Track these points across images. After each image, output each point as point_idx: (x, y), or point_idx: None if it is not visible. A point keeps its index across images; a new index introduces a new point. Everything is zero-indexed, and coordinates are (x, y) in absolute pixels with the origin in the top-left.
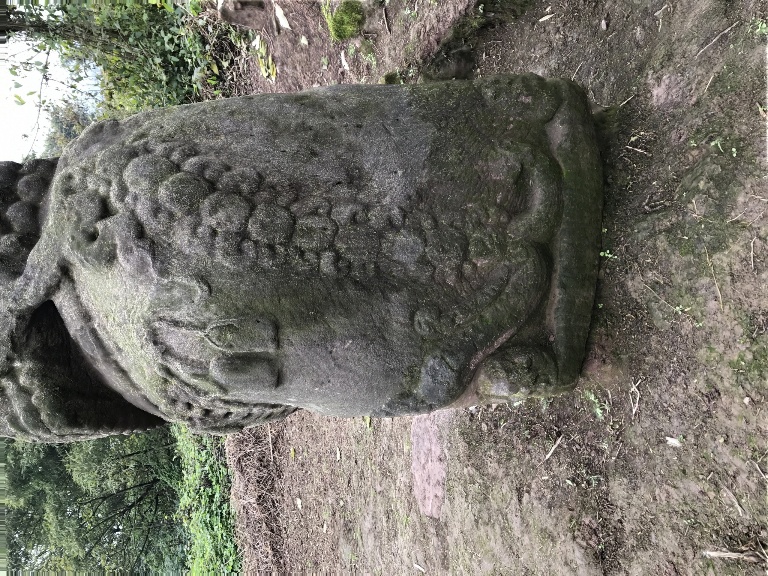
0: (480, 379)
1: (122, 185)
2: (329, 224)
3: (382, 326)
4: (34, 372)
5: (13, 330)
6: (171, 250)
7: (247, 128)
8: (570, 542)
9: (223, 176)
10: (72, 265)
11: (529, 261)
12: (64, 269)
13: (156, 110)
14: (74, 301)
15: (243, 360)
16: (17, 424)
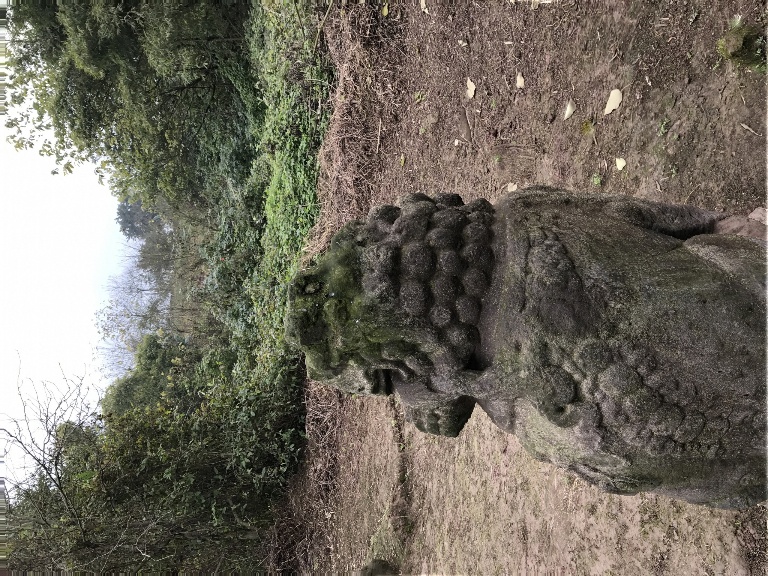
0: None
1: (596, 383)
2: (726, 425)
3: None
4: (448, 411)
5: None
6: (616, 437)
7: (700, 347)
8: (731, 533)
9: (673, 393)
10: None
11: None
12: None
13: (619, 283)
14: (510, 407)
15: None
16: (421, 427)
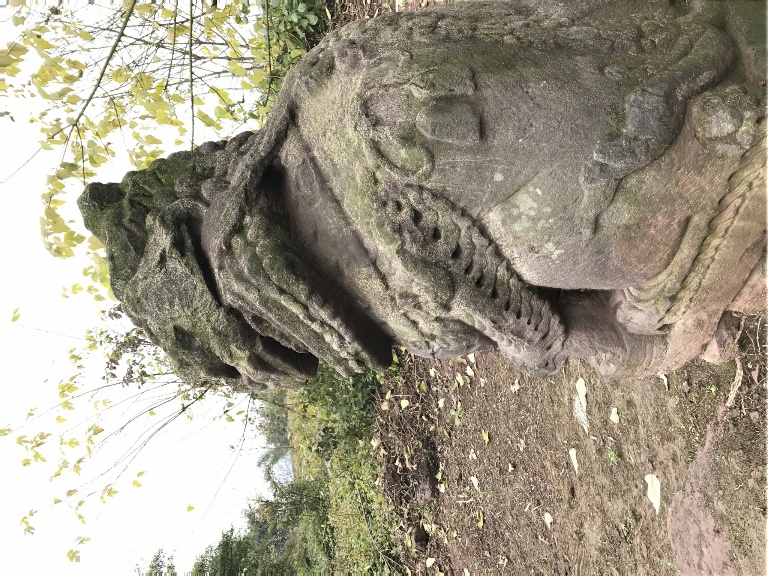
0: (694, 116)
1: (338, 36)
2: None
3: (573, 74)
4: (260, 225)
5: (247, 183)
6: (377, 45)
7: None
8: None
9: None
10: (298, 108)
11: (707, 31)
12: (292, 113)
13: None
14: (298, 139)
15: (446, 103)
16: (241, 276)
